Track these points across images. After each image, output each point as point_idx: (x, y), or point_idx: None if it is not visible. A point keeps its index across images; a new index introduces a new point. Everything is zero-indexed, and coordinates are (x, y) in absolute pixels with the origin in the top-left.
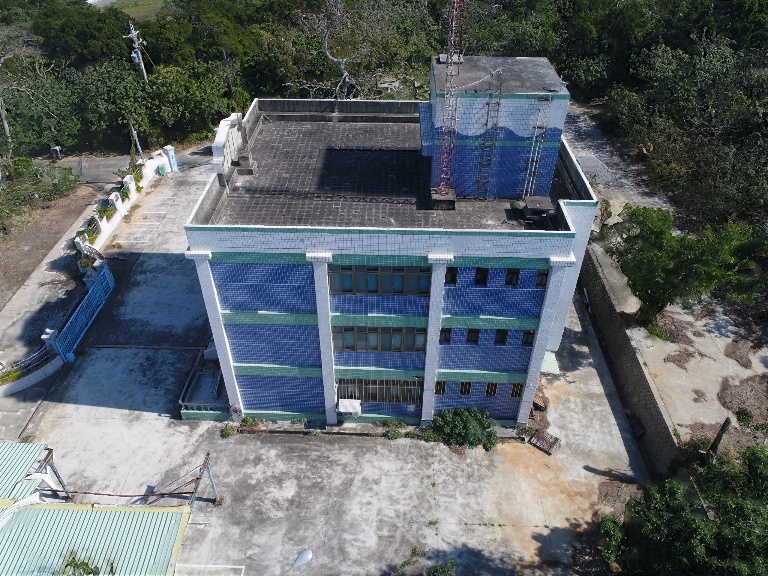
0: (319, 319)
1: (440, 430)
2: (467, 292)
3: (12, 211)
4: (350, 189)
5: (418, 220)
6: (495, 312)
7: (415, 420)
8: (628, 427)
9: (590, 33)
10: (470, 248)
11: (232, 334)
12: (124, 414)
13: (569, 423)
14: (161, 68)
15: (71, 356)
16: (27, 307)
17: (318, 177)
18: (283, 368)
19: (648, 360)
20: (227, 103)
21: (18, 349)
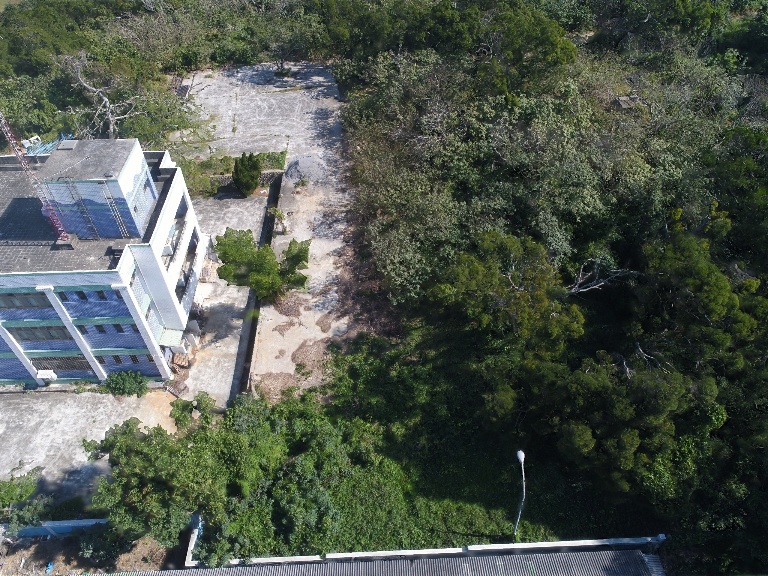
0: None
1: (110, 386)
2: (78, 304)
3: None
4: (15, 235)
5: (45, 259)
6: (104, 314)
7: (97, 380)
8: (240, 376)
9: (343, 37)
10: (60, 282)
11: None
12: None
13: (202, 376)
14: None
15: None
16: None
17: None
18: None
19: (262, 330)
20: (38, 114)
21: None
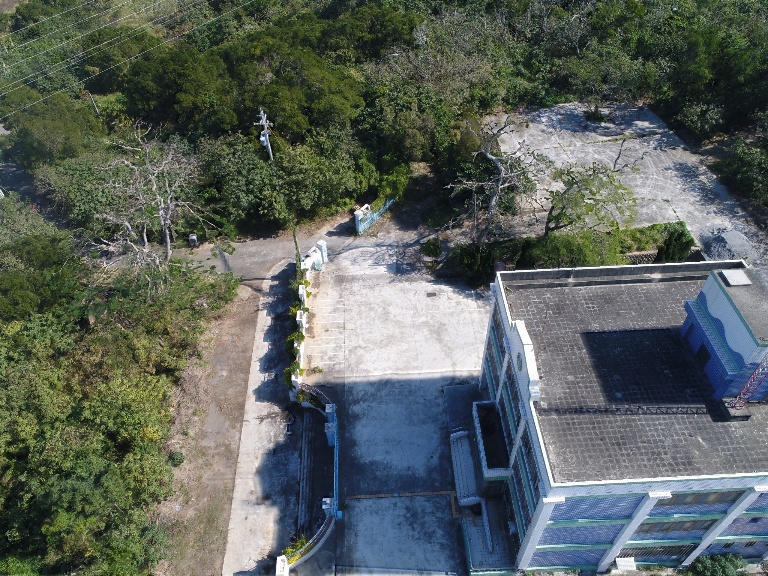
0: (632, 522)
1: (699, 573)
2: None
3: (193, 329)
4: (640, 396)
5: (722, 437)
6: None
7: (674, 564)
8: None
9: (705, 79)
10: None
11: (545, 531)
12: (415, 575)
13: None
14: (291, 150)
15: (341, 514)
16: (261, 449)
17: (602, 379)
18: (578, 546)
19: None
20: (354, 176)
21: (277, 501)
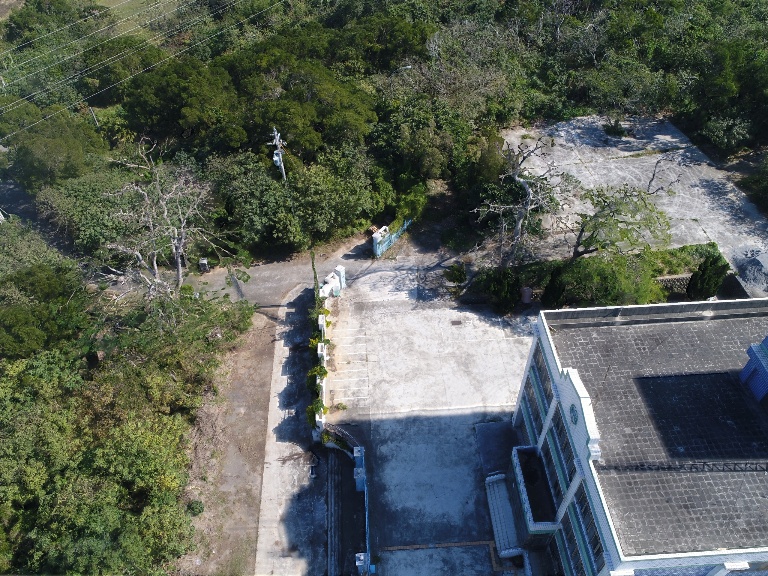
0: None
1: None
2: None
3: (207, 362)
4: (704, 450)
5: None
6: None
7: None
8: None
9: (732, 93)
10: None
11: None
12: None
13: None
14: (306, 170)
15: (374, 569)
16: (284, 494)
17: (661, 431)
18: None
19: None
20: (370, 196)
21: (304, 553)
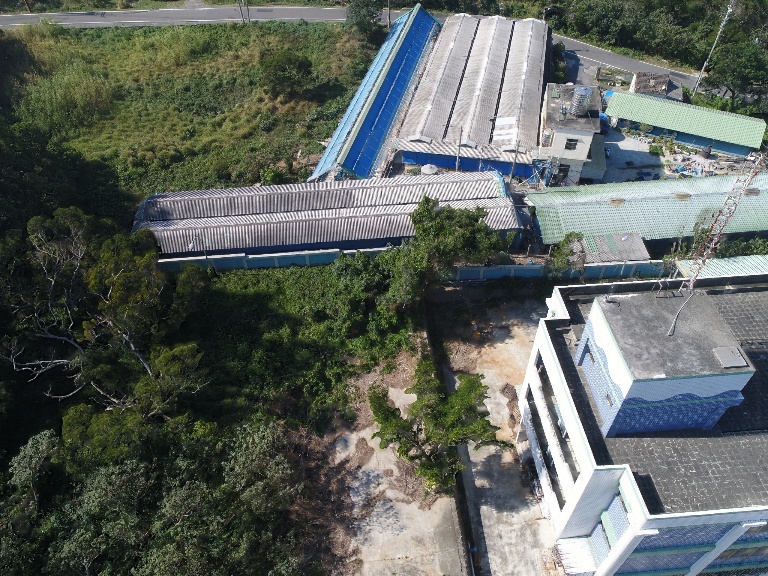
0: None
1: None
2: None
3: None
4: None
5: None
6: None
7: None
8: None
9: None
10: None
11: None
12: None
13: (494, 408)
14: None
15: None
16: None
17: None
18: None
19: None
20: None
21: None
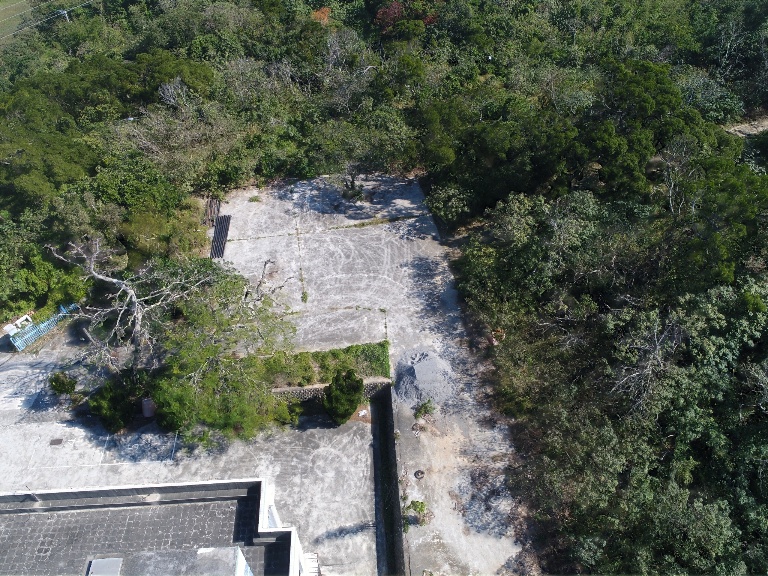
0: None
1: None
2: None
3: None
4: None
5: None
6: None
7: None
8: None
9: (448, 160)
10: None
11: None
12: None
13: None
14: None
15: None
16: None
17: None
18: None
19: None
20: (26, 277)
21: None
